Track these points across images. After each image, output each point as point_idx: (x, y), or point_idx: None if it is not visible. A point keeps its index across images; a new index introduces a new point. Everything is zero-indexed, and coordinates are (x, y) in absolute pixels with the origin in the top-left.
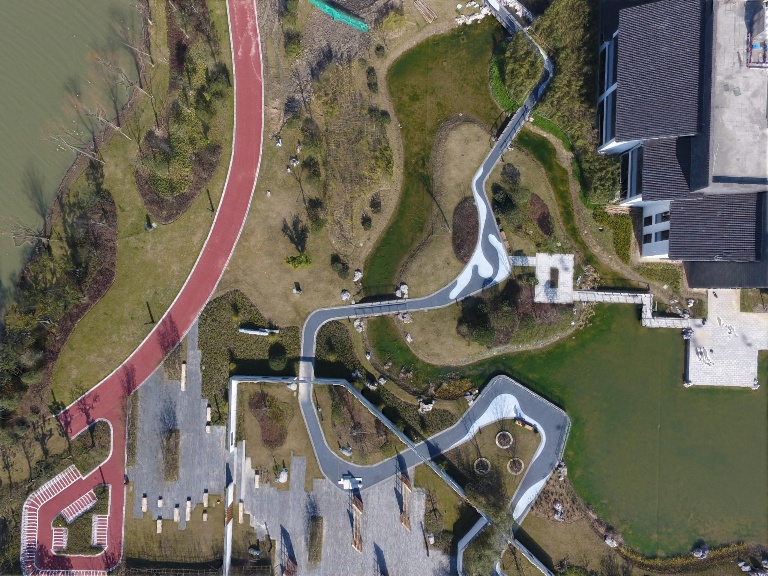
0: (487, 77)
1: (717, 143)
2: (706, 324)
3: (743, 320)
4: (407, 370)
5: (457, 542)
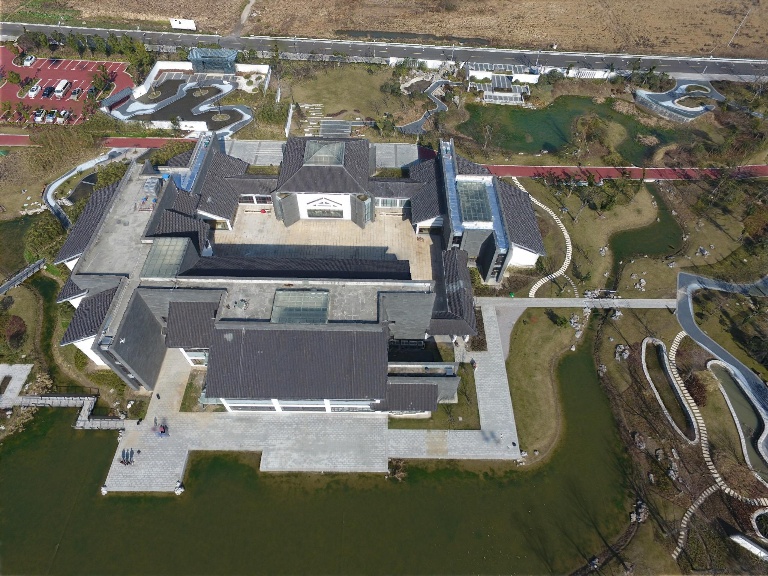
0: None
1: (97, 253)
2: (141, 424)
3: (180, 419)
4: None
5: None
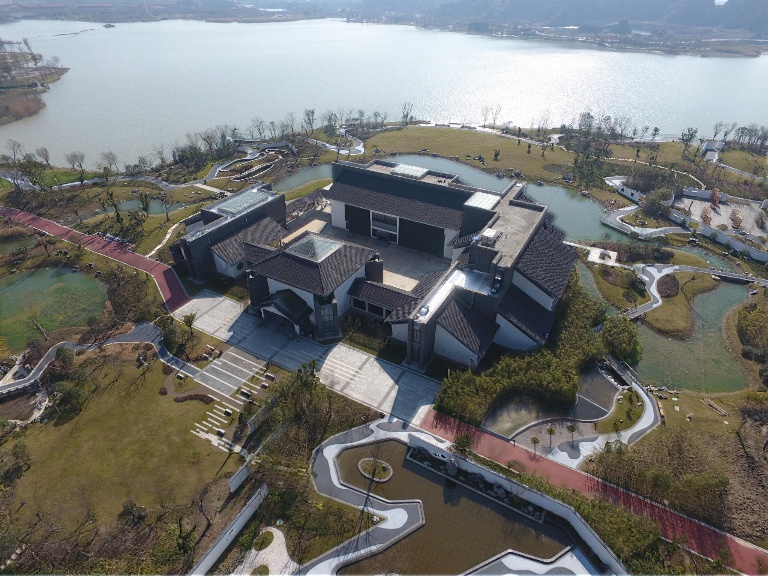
0: (644, 352)
1: None
2: None
3: None
4: (707, 255)
5: (672, 206)
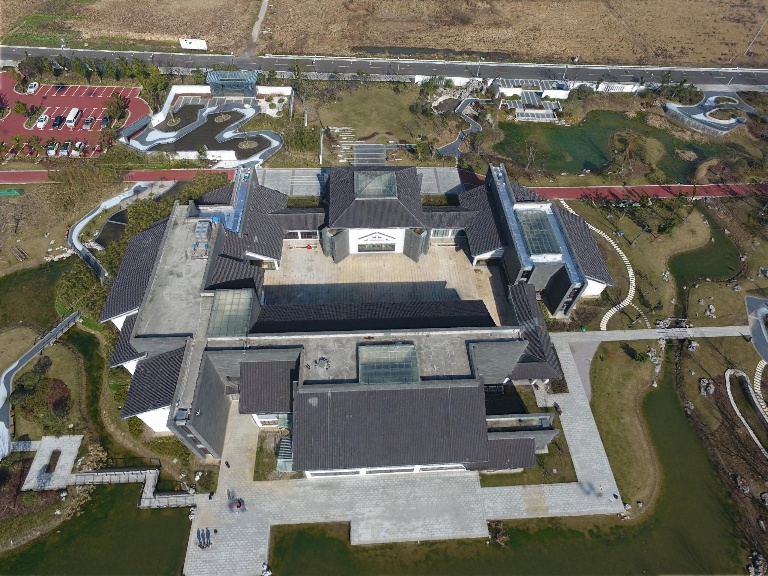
0: (57, 294)
1: (154, 310)
2: (213, 499)
3: (256, 490)
4: None
5: None
